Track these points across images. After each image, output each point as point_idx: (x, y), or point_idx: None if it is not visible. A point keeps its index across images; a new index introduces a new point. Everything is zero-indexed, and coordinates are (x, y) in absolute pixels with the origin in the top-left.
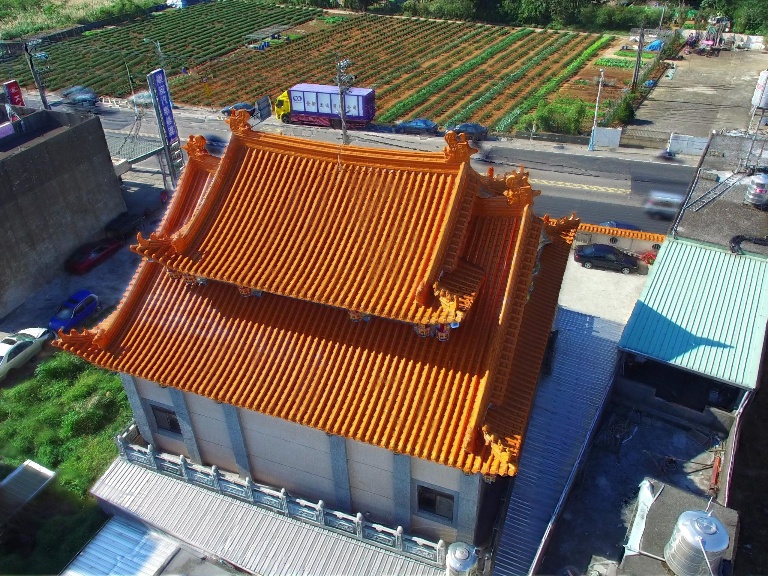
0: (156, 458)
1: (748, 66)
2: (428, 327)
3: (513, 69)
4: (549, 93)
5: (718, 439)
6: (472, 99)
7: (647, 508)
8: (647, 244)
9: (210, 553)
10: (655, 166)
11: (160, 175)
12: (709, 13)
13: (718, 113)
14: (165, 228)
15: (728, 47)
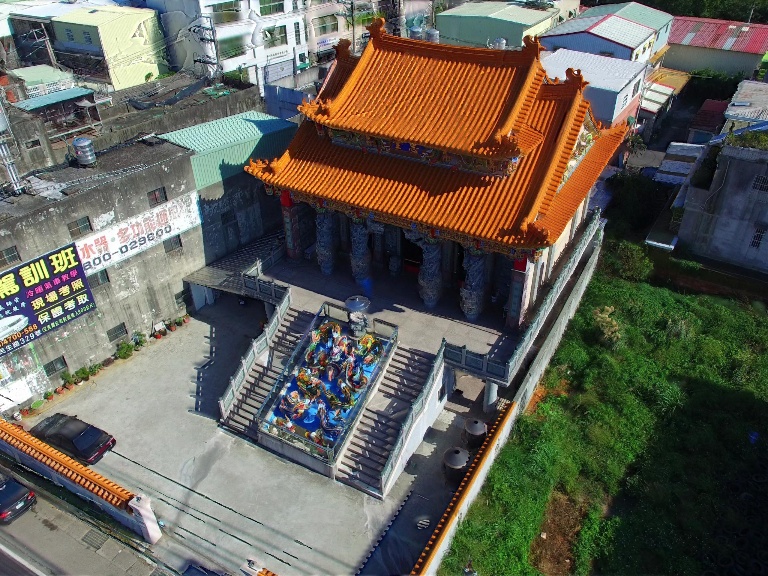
0: None
1: None
2: None
3: None
4: None
5: None
6: None
7: None
8: None
9: None
10: None
11: None
12: None
13: None
14: None
15: None
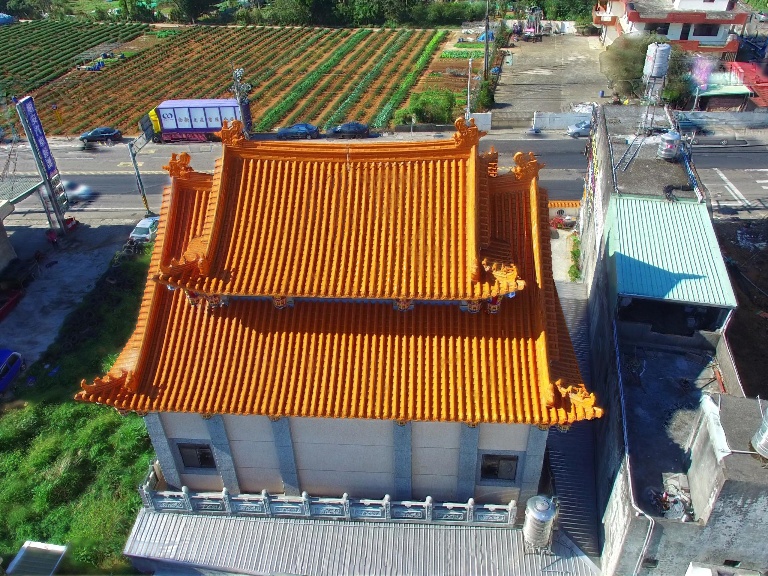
0: (192, 499)
1: (569, 48)
2: (480, 302)
3: (368, 68)
4: (410, 87)
5: (710, 356)
6: (341, 100)
7: (718, 416)
8: (553, 211)
9: None
10: (528, 143)
11: (34, 214)
12: (525, 4)
13: (561, 91)
14: (164, 255)
15: (547, 33)
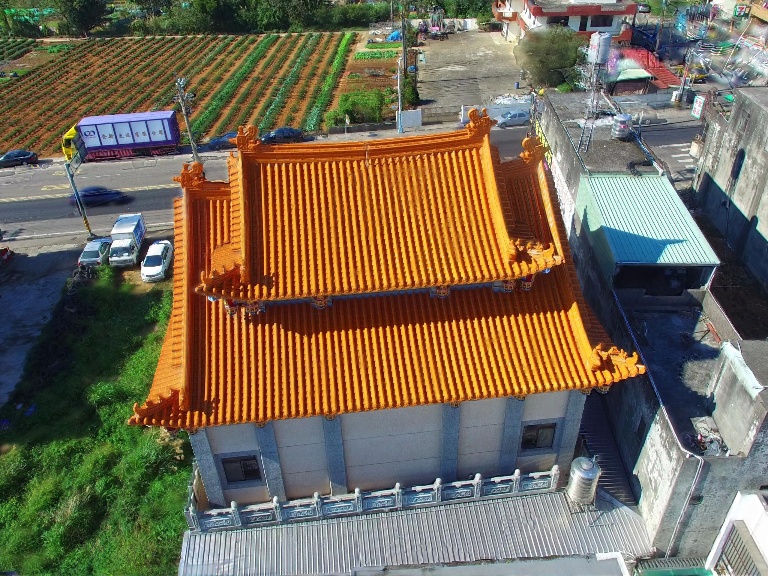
0: (241, 513)
1: (476, 44)
2: (515, 281)
3: (285, 73)
4: (333, 90)
5: (699, 311)
6: (266, 106)
7: (742, 359)
8: None
9: (349, 575)
10: None
11: None
12: (427, 3)
13: (479, 85)
14: (189, 268)
15: (452, 30)
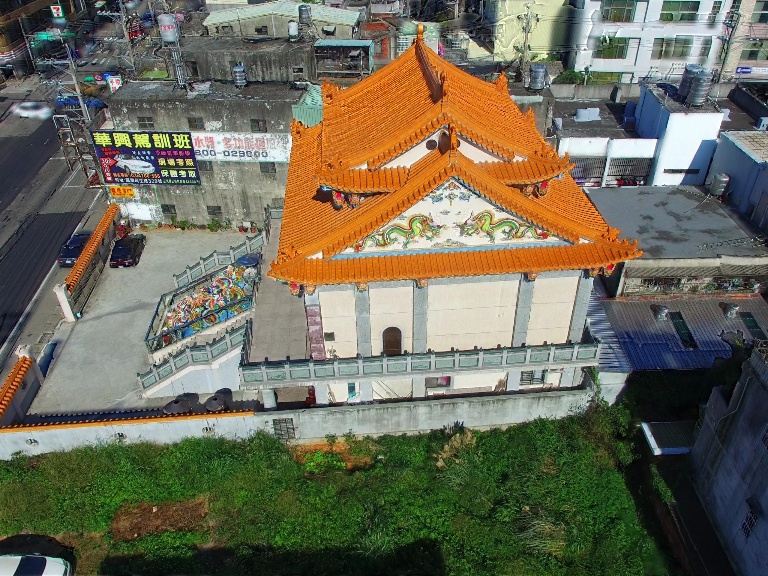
0: None
1: None
2: None
3: None
4: None
5: None
6: None
7: None
8: None
9: None
10: None
11: None
12: None
13: None
14: None
15: None
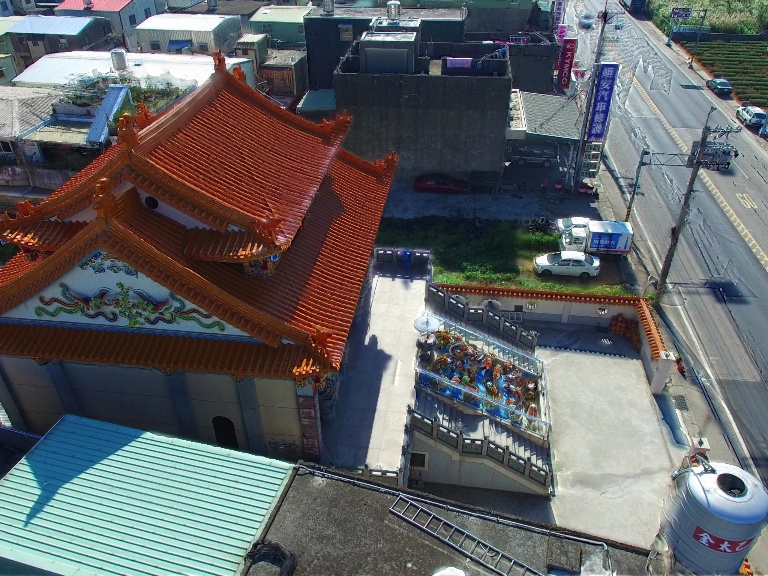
0: None
1: None
2: None
3: None
4: None
5: None
6: None
7: None
8: None
9: None
10: None
11: (607, 173)
12: None
13: None
14: None
15: None
